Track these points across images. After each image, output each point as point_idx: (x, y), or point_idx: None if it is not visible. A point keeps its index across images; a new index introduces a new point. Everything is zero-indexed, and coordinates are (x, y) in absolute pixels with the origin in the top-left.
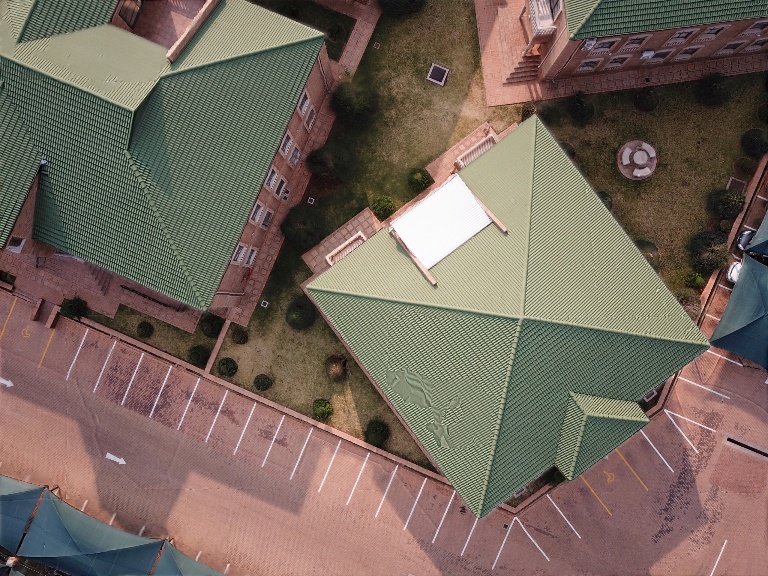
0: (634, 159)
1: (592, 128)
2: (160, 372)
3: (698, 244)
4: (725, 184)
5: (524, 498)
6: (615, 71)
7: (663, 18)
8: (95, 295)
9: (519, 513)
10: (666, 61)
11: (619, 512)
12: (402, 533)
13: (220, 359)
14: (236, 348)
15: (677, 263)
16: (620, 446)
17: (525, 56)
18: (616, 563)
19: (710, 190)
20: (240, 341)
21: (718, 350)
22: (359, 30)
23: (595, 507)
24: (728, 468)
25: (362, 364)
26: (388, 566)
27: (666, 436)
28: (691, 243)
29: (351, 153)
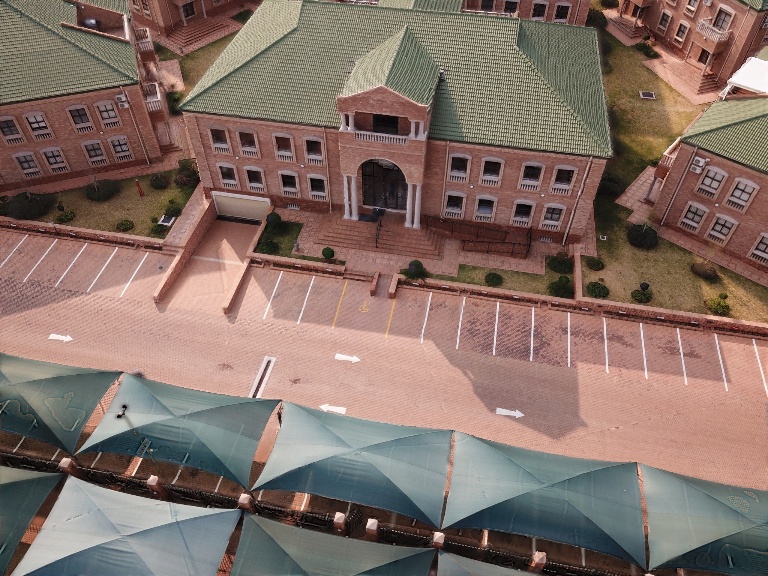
0: None
1: None
2: (523, 316)
3: None
4: None
5: None
6: None
7: None
8: (432, 262)
9: None
10: None
11: None
12: None
13: (586, 285)
14: (596, 274)
15: None
16: None
17: (704, 75)
18: None
19: None
20: (598, 266)
21: None
22: None
23: None
24: None
25: None
26: None
27: None
28: None
29: None
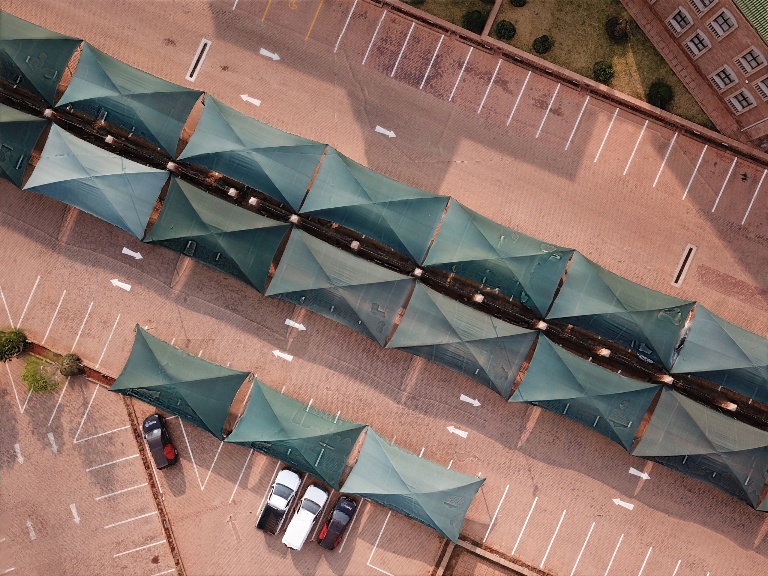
0: None
1: None
2: (431, 42)
3: None
4: None
5: None
6: None
7: None
8: None
9: None
10: None
11: None
12: (681, 202)
13: (498, 22)
14: (514, 11)
15: None
16: None
17: None
18: None
19: None
20: (519, 2)
21: None
22: None
23: None
24: None
25: None
26: (666, 236)
27: None
28: None
29: None
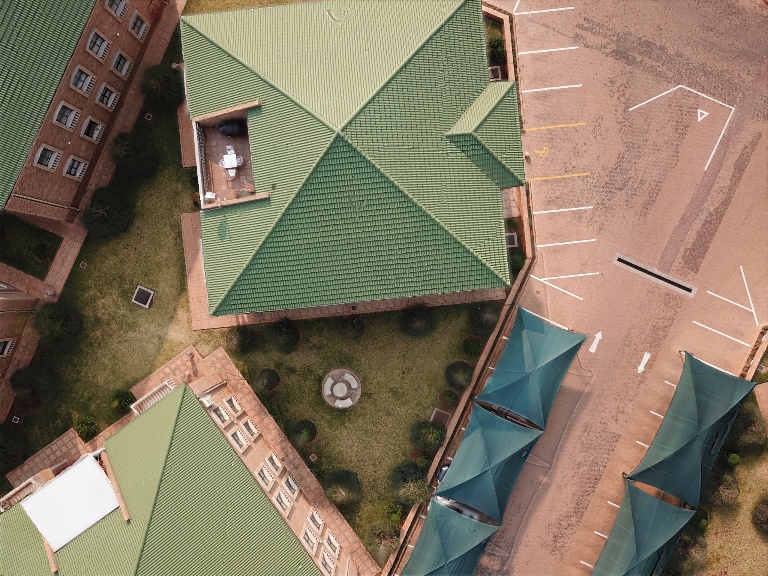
0: (334, 391)
1: (298, 355)
2: None
3: (397, 478)
4: (430, 415)
5: None
6: None
7: (302, 298)
8: None
9: None
10: None
11: None
12: None
13: None
14: None
15: (380, 493)
16: None
17: None
18: None
19: (414, 421)
20: None
21: None
22: (65, 249)
23: None
24: None
25: None
26: None
27: None
28: (393, 475)
29: (56, 373)
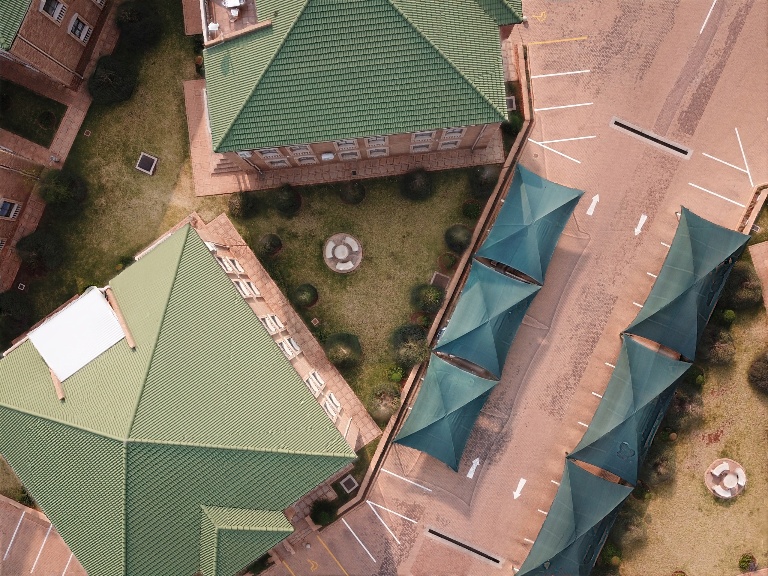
0: (335, 253)
1: (299, 220)
2: None
3: (397, 339)
4: (430, 278)
5: None
6: (320, 164)
7: (304, 133)
8: None
9: None
10: (365, 157)
11: None
12: None
13: None
14: None
15: (381, 356)
16: (323, 535)
17: None
18: None
19: (414, 284)
20: None
21: None
22: (70, 117)
23: None
24: (429, 559)
25: (13, 468)
26: None
27: (368, 526)
28: (393, 337)
29: (61, 240)
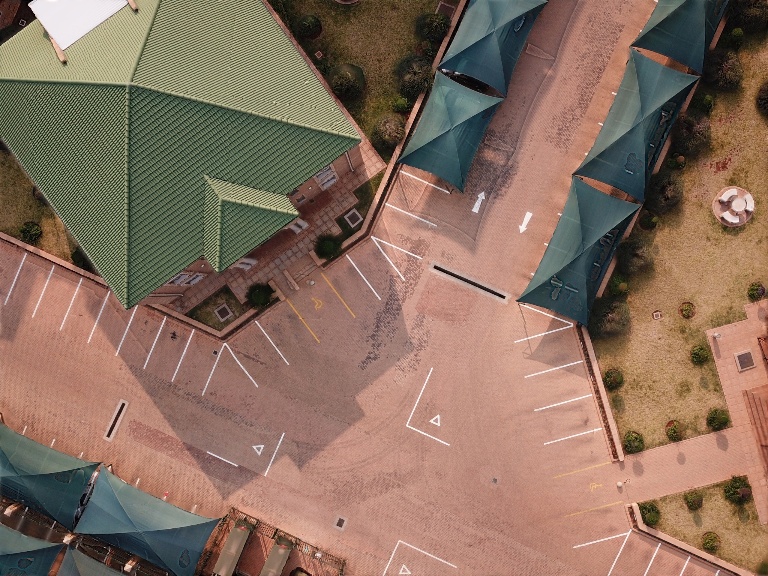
0: None
1: None
2: None
3: (402, 67)
4: (434, 9)
5: (230, 322)
6: None
7: None
8: None
9: (227, 339)
10: None
11: (327, 339)
12: (114, 359)
13: None
14: None
15: (385, 88)
16: (327, 273)
17: None
18: (323, 390)
19: (419, 15)
20: None
21: (425, 177)
22: None
23: (303, 334)
24: (434, 296)
25: None
26: (100, 391)
27: (373, 263)
28: (398, 67)
29: None
